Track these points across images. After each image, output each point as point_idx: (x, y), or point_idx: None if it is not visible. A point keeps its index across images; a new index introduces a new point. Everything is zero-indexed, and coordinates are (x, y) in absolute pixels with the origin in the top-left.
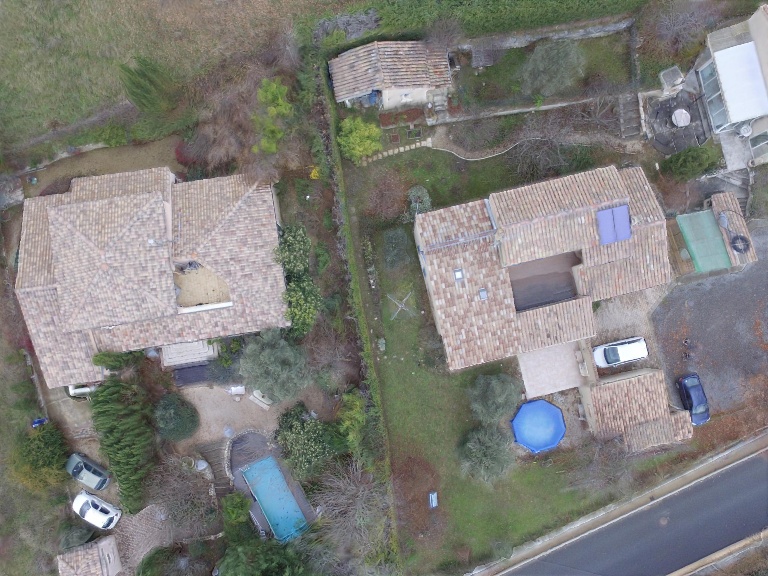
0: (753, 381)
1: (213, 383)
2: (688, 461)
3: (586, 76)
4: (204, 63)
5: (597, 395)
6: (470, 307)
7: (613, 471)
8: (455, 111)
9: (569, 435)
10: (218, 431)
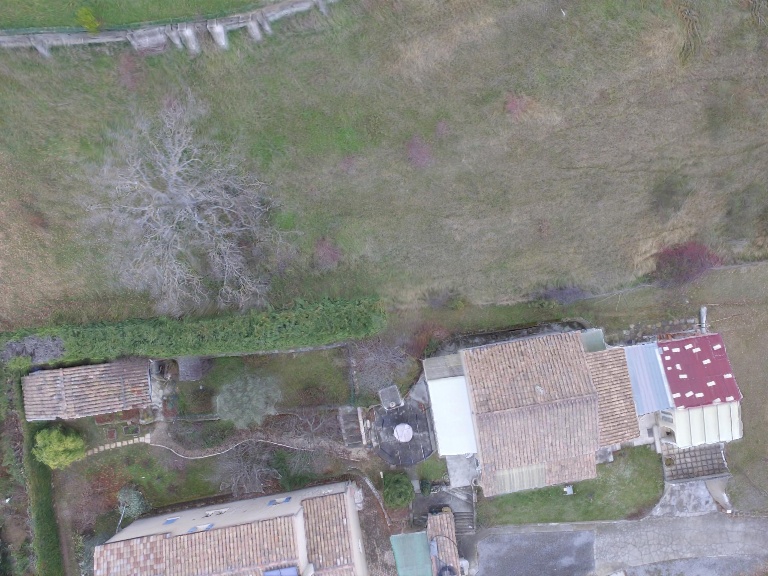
0: None
1: None
2: None
3: (306, 385)
4: None
5: None
6: None
7: None
8: (169, 414)
9: None
10: None
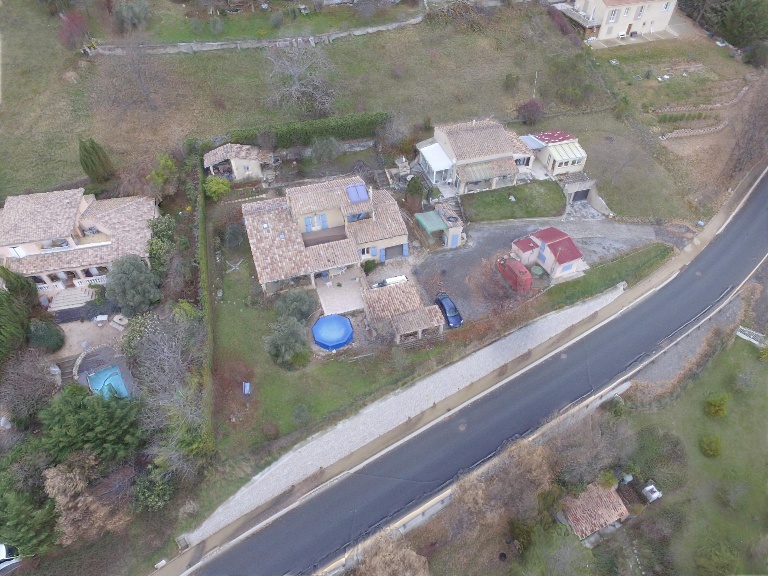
0: (491, 300)
1: (84, 316)
2: (450, 346)
3: None
4: None
5: (367, 296)
6: (273, 244)
7: None
8: (279, 180)
9: (358, 338)
10: (77, 349)
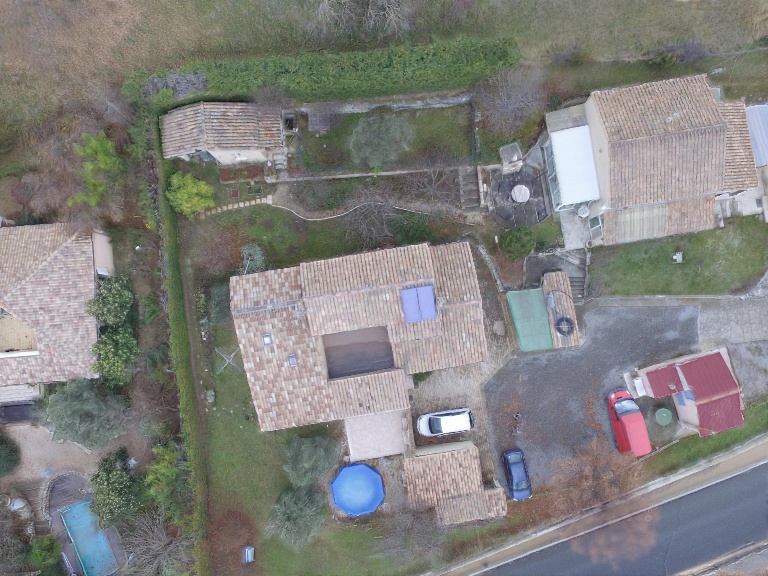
0: (580, 461)
1: (37, 423)
2: (506, 537)
3: (427, 145)
4: (42, 108)
5: (410, 467)
6: (280, 372)
7: (434, 540)
8: (294, 171)
9: (390, 501)
10: (41, 470)
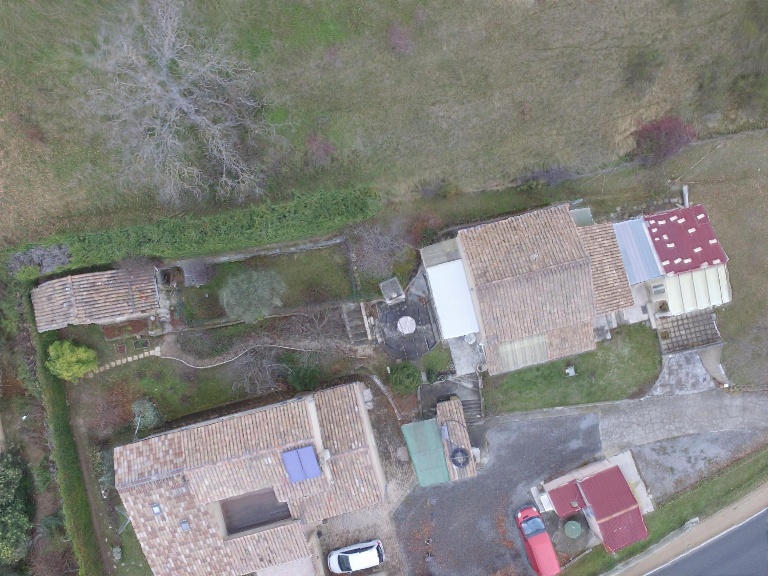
0: None
1: None
2: None
3: (309, 286)
4: None
5: None
6: (174, 538)
7: None
8: (178, 324)
9: None
10: None
